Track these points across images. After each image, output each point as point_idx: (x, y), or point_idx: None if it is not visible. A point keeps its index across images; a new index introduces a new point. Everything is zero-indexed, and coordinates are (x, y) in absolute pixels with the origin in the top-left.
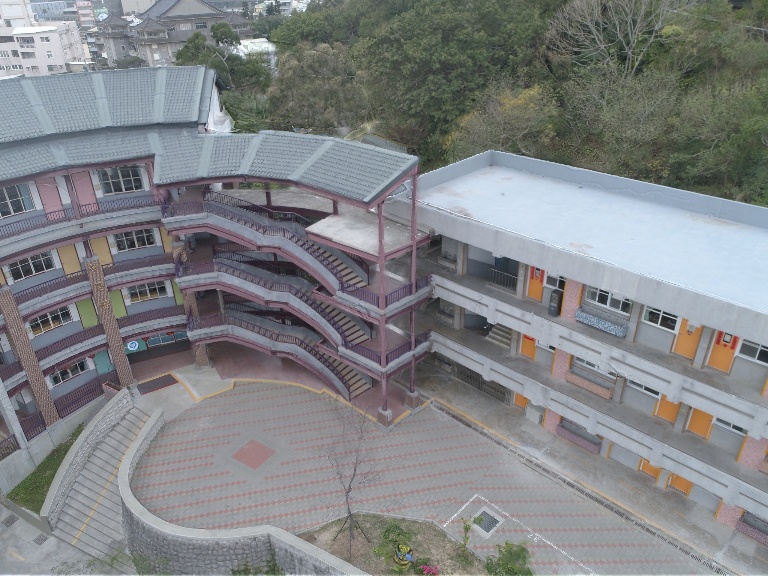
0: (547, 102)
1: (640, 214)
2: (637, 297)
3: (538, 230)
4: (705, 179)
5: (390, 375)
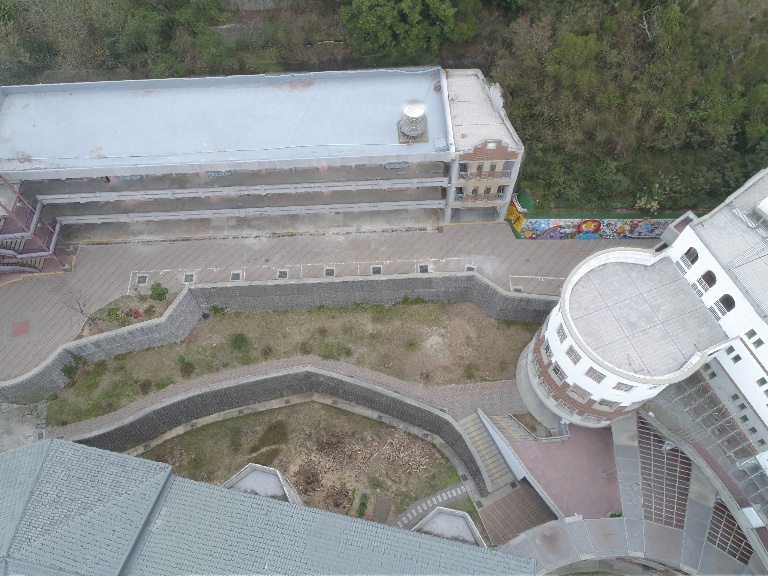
0: (6, 29)
1: (111, 106)
2: (134, 174)
3: (71, 149)
4: (129, 50)
5: (54, 252)
